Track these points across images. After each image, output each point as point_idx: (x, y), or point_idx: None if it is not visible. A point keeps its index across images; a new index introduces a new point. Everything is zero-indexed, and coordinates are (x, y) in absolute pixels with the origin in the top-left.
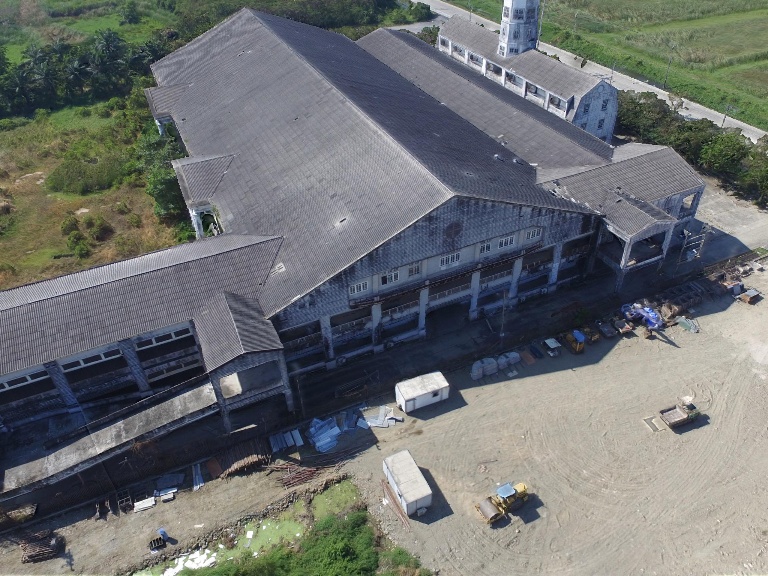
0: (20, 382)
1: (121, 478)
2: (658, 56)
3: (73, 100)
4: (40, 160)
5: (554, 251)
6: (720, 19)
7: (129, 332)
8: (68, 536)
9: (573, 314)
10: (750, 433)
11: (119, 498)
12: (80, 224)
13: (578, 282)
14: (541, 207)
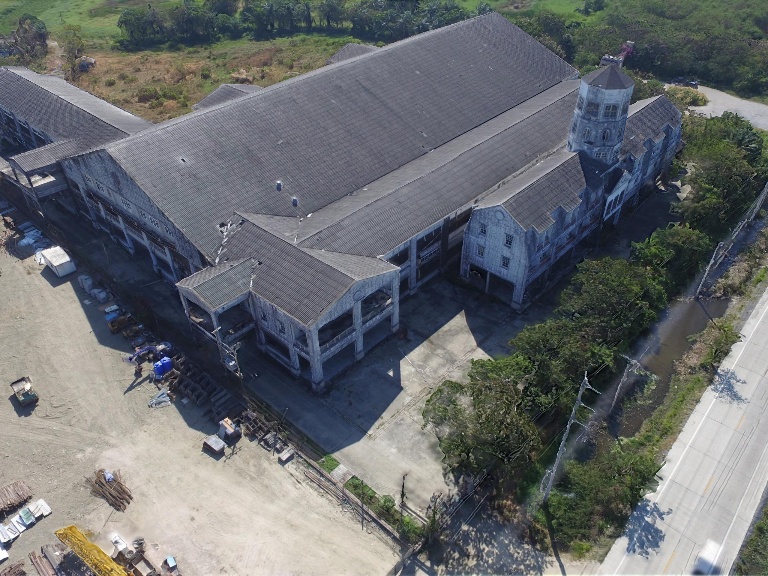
0: None
1: None
2: None
3: None
4: None
5: None
6: None
7: None
8: None
9: None
10: (3, 443)
11: None
12: None
13: None
14: (160, 208)
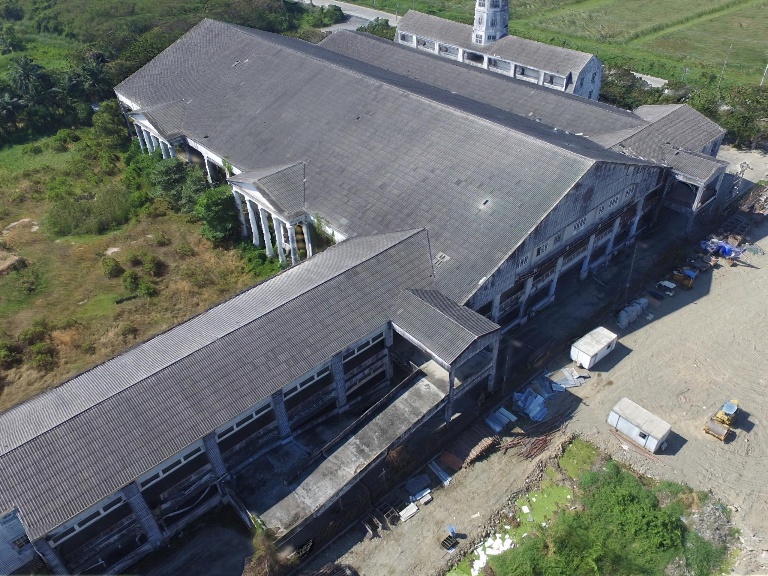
0: (246, 421)
1: (377, 492)
2: (576, 35)
3: (10, 138)
4: (16, 206)
5: (638, 205)
6: (602, 0)
7: (338, 345)
8: (353, 563)
9: (672, 257)
10: None
11: (383, 512)
12: (121, 264)
13: (646, 232)
14: (640, 165)
